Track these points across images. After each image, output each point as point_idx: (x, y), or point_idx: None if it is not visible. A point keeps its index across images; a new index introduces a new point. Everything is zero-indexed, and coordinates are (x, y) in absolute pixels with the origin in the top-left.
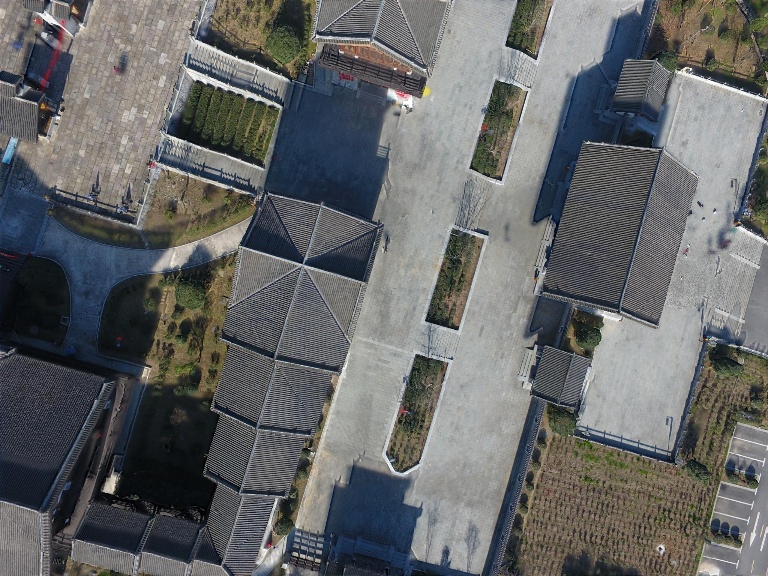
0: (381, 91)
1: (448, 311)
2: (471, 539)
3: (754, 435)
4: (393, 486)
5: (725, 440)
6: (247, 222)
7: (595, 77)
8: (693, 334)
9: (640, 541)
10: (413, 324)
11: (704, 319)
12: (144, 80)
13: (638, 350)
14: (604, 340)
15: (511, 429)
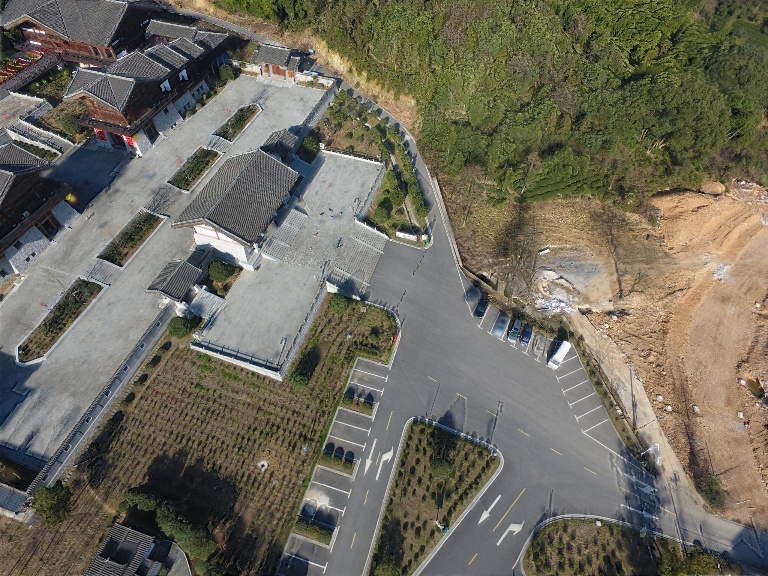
0: (126, 149)
1: (120, 256)
2: (60, 426)
3: (374, 368)
4: (11, 375)
5: (345, 370)
6: None
7: None
8: (314, 282)
9: (241, 453)
10: (86, 259)
11: (324, 273)
12: None
13: (267, 290)
14: (241, 283)
15: (138, 336)
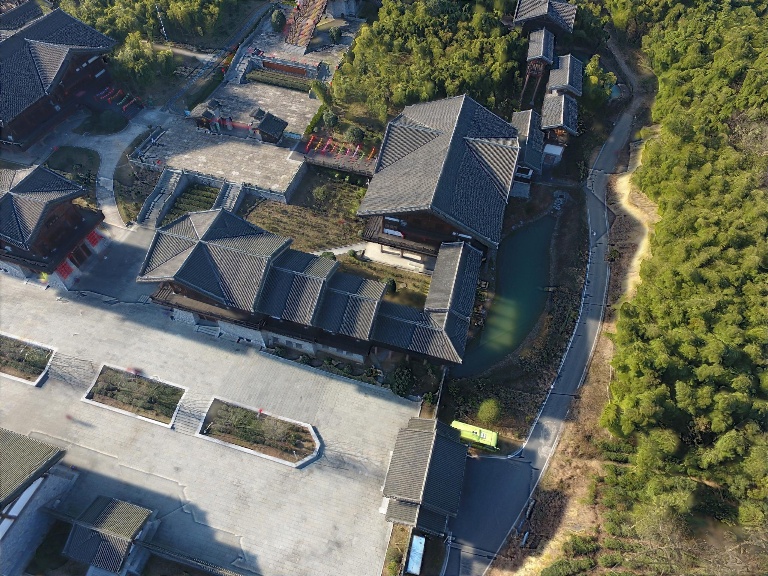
0: None
1: None
2: None
3: None
4: None
5: None
6: (118, 217)
7: (168, 503)
8: None
9: None
10: None
11: None
12: (223, 165)
13: None
14: None
15: None
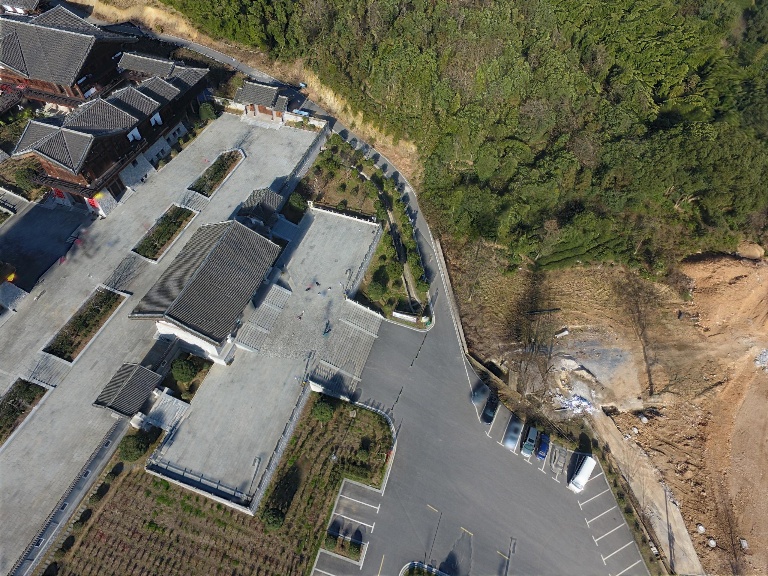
0: None
1: (71, 347)
2: None
3: (364, 494)
4: None
5: (329, 497)
6: None
7: None
8: (296, 380)
9: None
10: (30, 353)
11: (308, 368)
12: None
13: (240, 391)
14: (210, 381)
15: (83, 457)
